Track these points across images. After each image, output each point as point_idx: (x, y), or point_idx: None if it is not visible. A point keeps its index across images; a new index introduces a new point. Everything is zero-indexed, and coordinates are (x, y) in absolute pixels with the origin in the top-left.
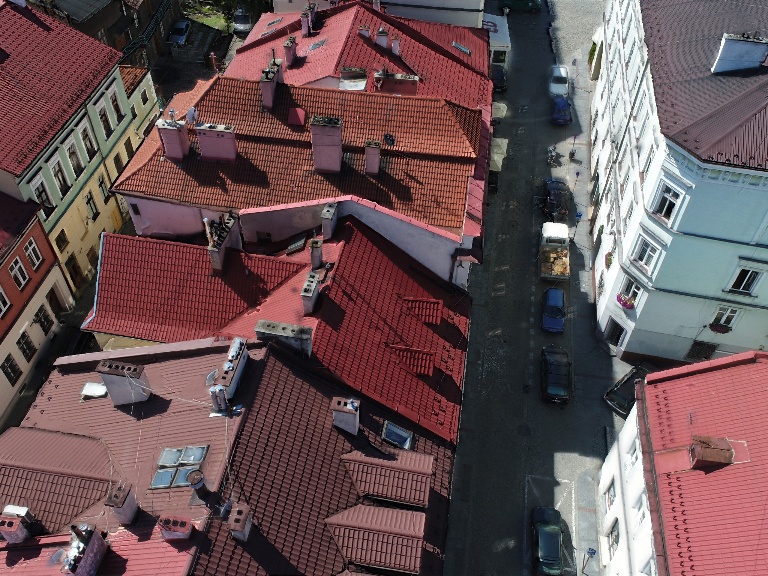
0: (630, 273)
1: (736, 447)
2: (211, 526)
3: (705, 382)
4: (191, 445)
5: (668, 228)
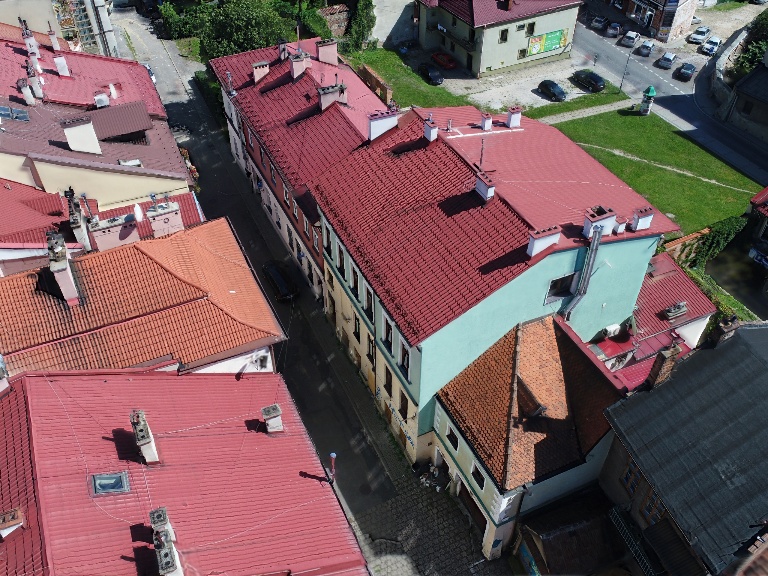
0: None
1: None
2: None
3: None
4: (10, 120)
5: None
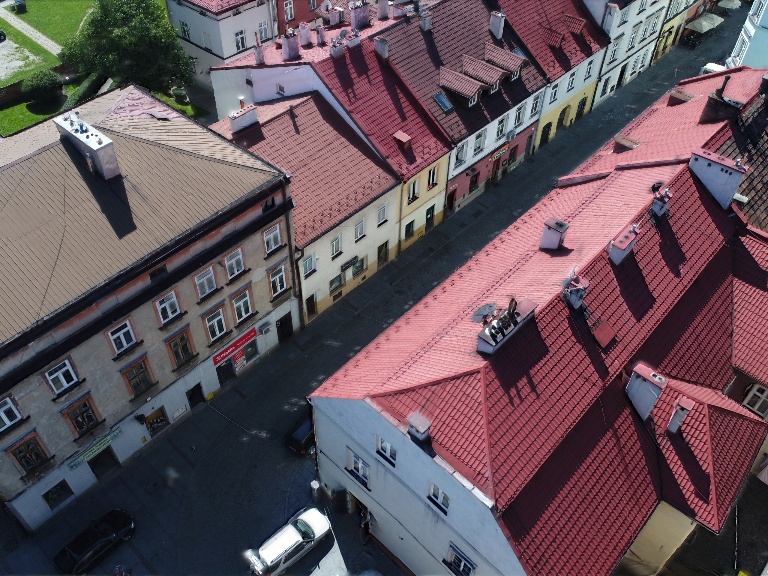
0: (729, 66)
1: (696, 97)
2: (414, 18)
3: (708, 81)
4: None
5: (755, 22)
